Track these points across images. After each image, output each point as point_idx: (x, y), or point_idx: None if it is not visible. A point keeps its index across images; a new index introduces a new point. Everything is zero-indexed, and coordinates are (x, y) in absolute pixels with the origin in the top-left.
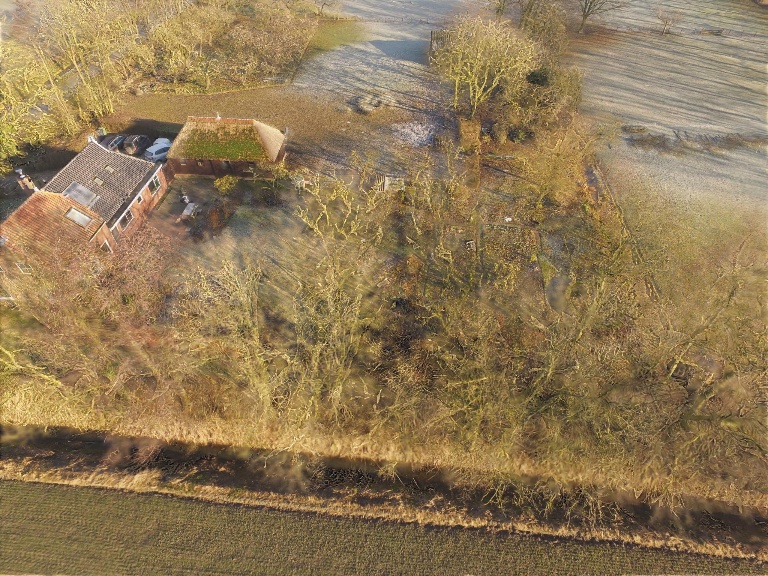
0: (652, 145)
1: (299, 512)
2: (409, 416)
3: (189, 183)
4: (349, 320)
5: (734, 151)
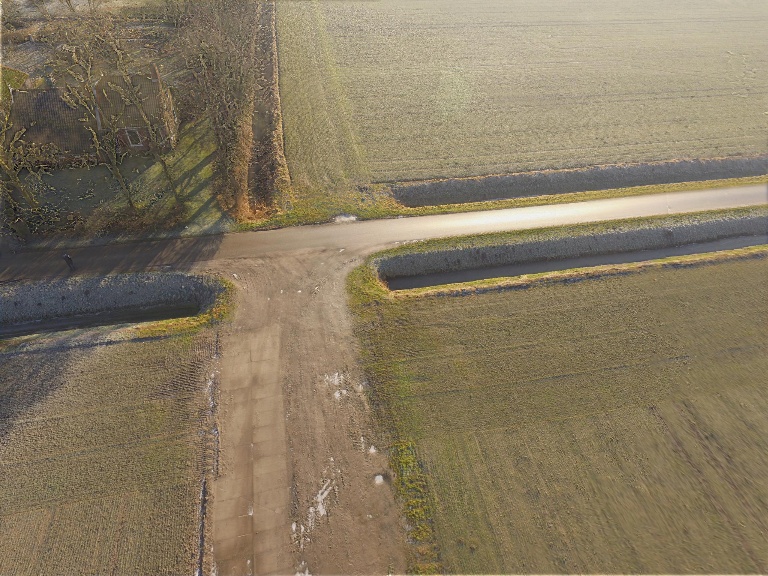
0: (40, 1)
1: None
2: None
3: None
4: None
5: None
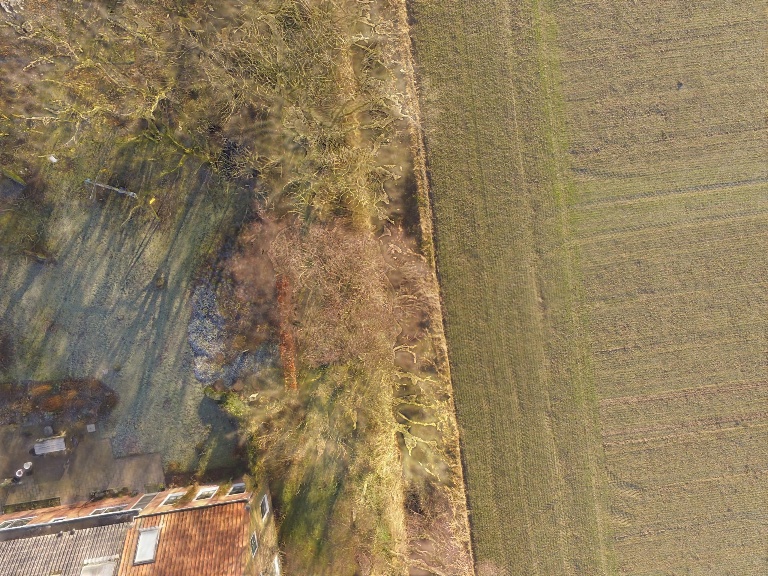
0: None
1: (424, 139)
2: (348, 7)
3: None
4: (312, 8)
5: None
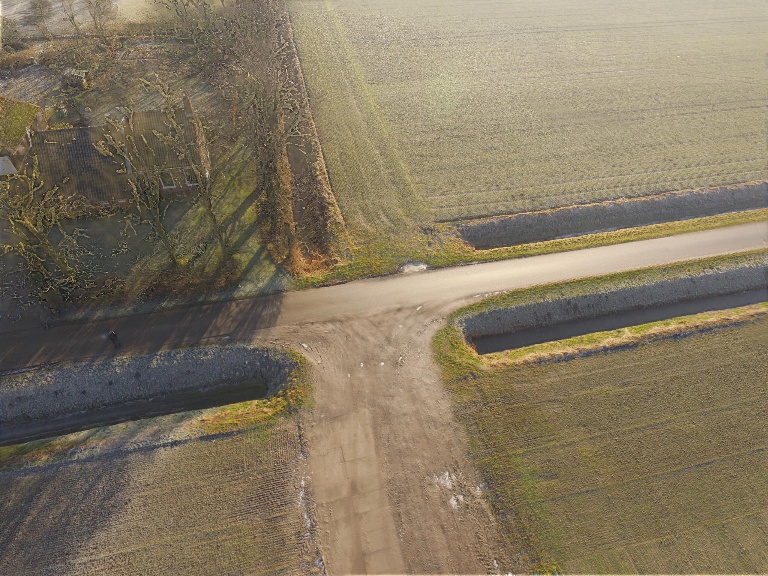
0: (38, 19)
1: (305, 81)
2: None
3: None
4: None
5: (53, 4)
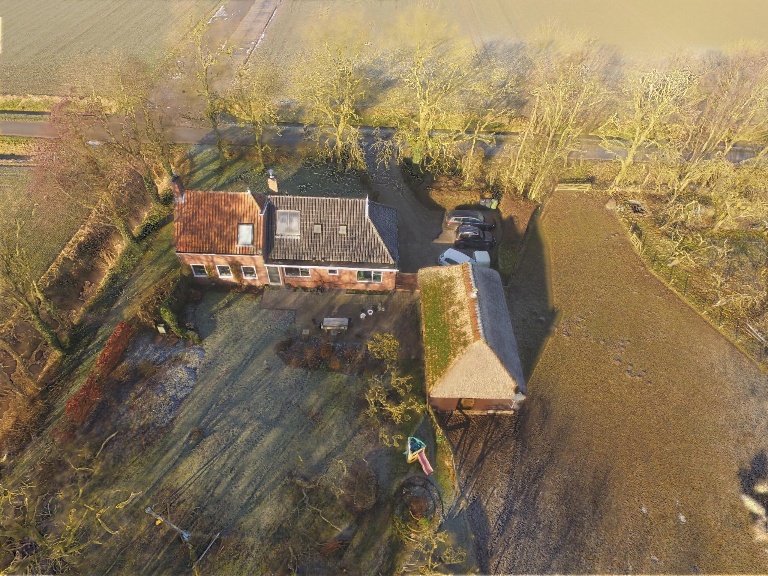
0: None
1: None
2: None
3: (405, 308)
4: None
5: None
